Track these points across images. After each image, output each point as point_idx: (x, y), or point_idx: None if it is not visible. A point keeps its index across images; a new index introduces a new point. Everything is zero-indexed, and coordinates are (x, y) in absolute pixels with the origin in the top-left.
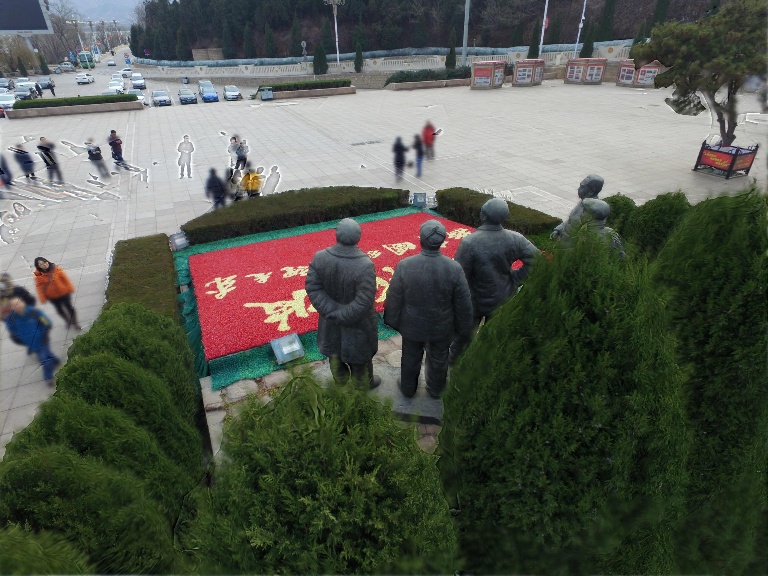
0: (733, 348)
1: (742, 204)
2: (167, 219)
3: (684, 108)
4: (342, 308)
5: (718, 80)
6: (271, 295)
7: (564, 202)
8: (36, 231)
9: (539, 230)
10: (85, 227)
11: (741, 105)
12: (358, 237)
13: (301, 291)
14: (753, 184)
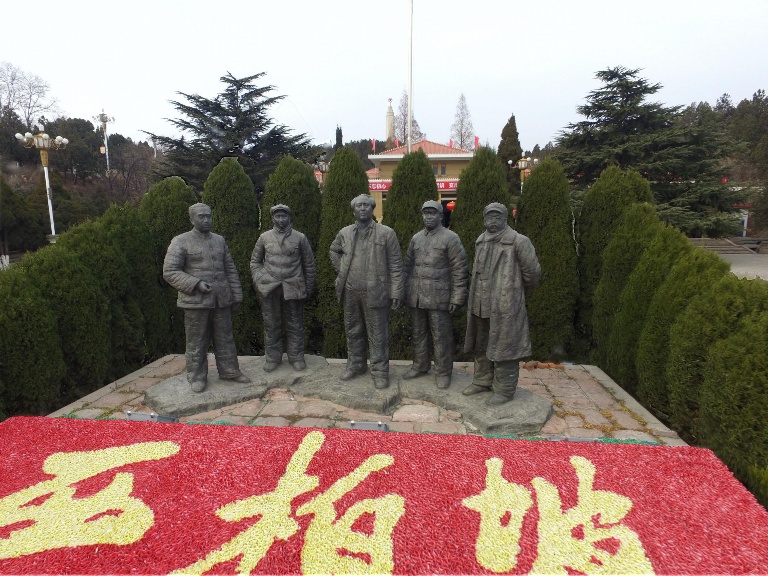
0: None
1: None
2: None
3: None
4: None
5: None
6: None
7: None
8: None
9: None
10: None
11: None
12: None
13: None
14: None
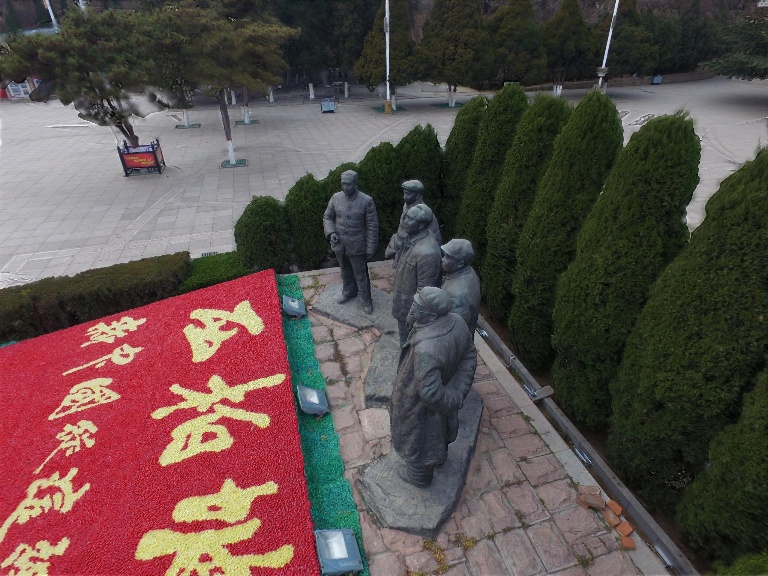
0: (697, 178)
1: (682, 118)
2: None
3: (104, 120)
4: (460, 381)
5: (124, 88)
6: None
7: (89, 250)
8: None
9: (185, 271)
10: None
11: (142, 108)
12: None
13: (146, 542)
14: (181, 170)
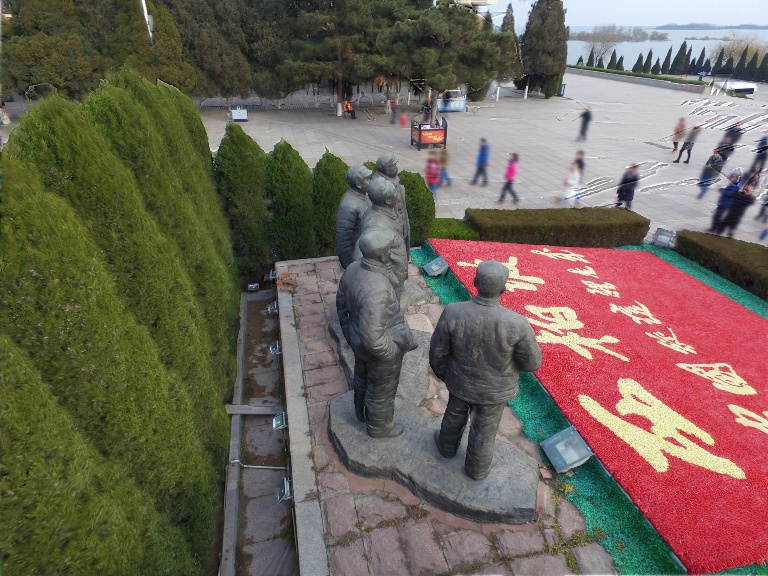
0: None
1: None
2: (745, 238)
3: None
4: None
5: None
6: (533, 268)
7: None
8: (668, 194)
9: None
10: (691, 208)
11: None
12: (379, 166)
13: (541, 281)
14: None
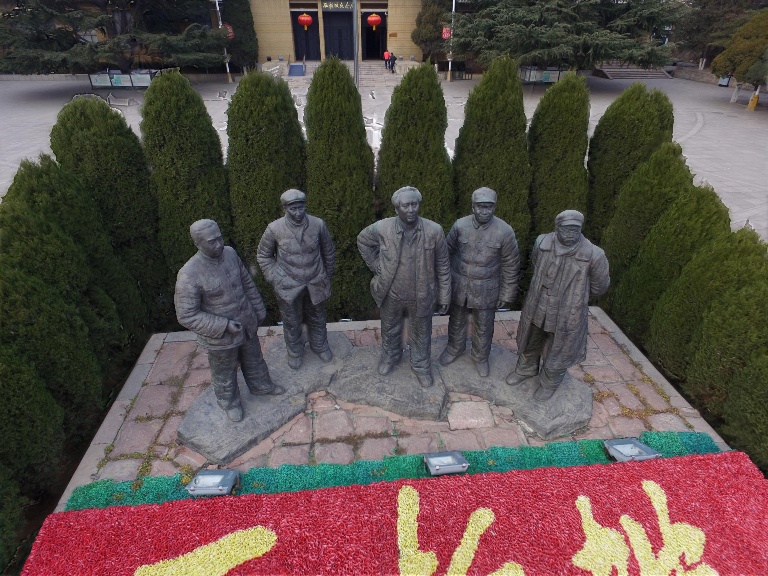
0: None
1: None
2: None
3: None
4: None
5: None
6: None
7: None
8: None
9: None
10: None
11: None
12: None
13: None
14: None
